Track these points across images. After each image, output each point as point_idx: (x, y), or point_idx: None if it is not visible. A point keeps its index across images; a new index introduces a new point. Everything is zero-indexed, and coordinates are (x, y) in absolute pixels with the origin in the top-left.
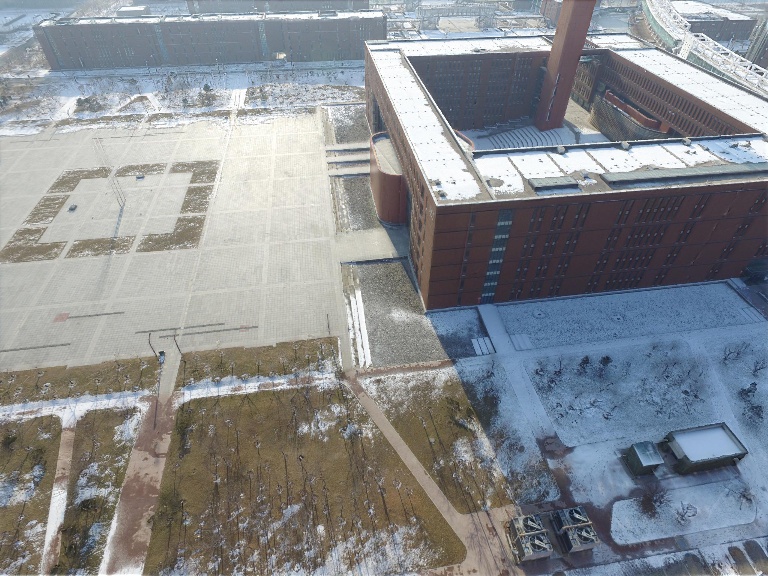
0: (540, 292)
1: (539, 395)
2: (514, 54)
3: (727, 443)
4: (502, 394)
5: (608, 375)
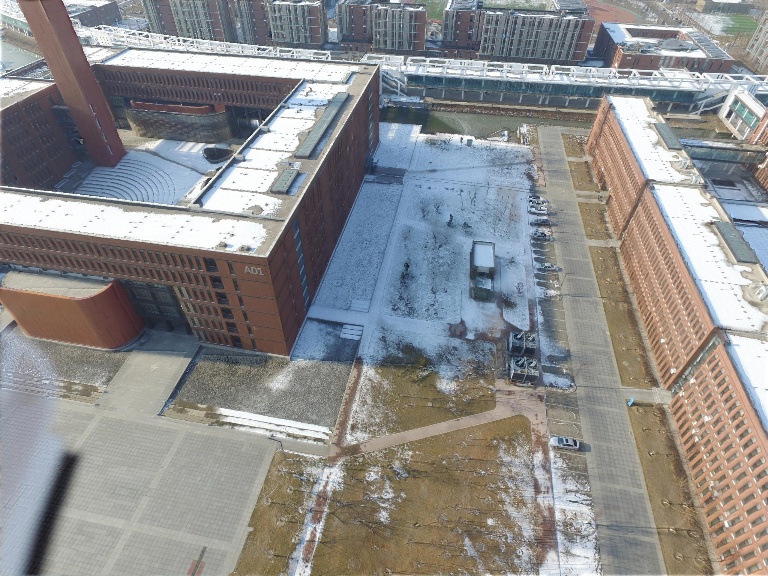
0: (322, 269)
1: (414, 318)
2: (15, 106)
3: (485, 248)
4: (405, 339)
5: (413, 273)
